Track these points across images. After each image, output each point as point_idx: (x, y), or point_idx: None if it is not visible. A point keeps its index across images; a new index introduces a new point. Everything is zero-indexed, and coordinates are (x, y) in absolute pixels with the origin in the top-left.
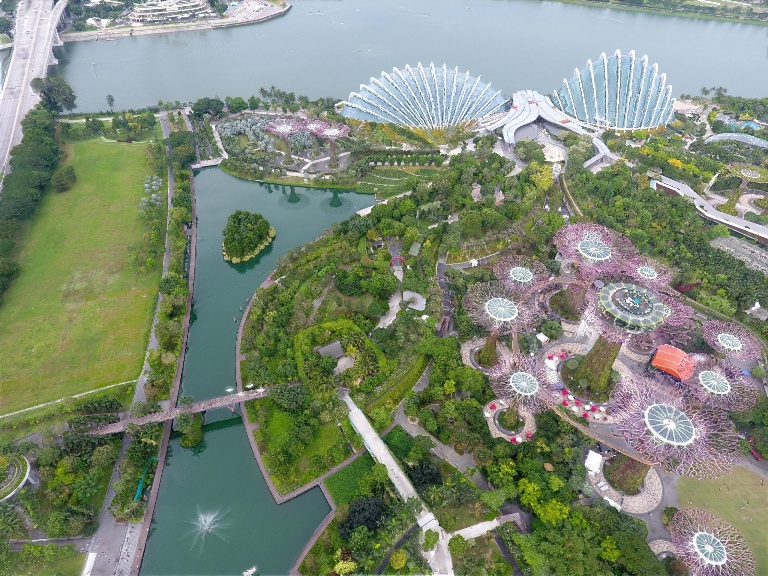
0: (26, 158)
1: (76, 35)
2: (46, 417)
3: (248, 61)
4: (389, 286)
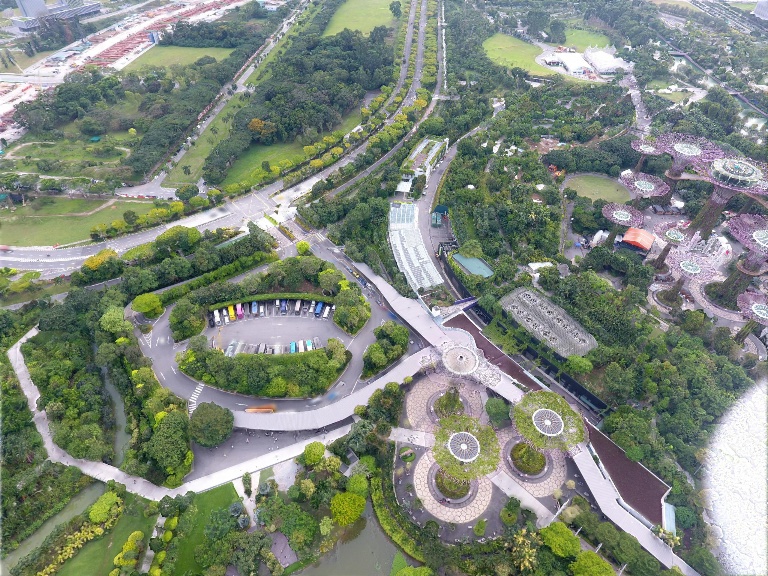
0: None
1: None
2: None
3: None
4: None
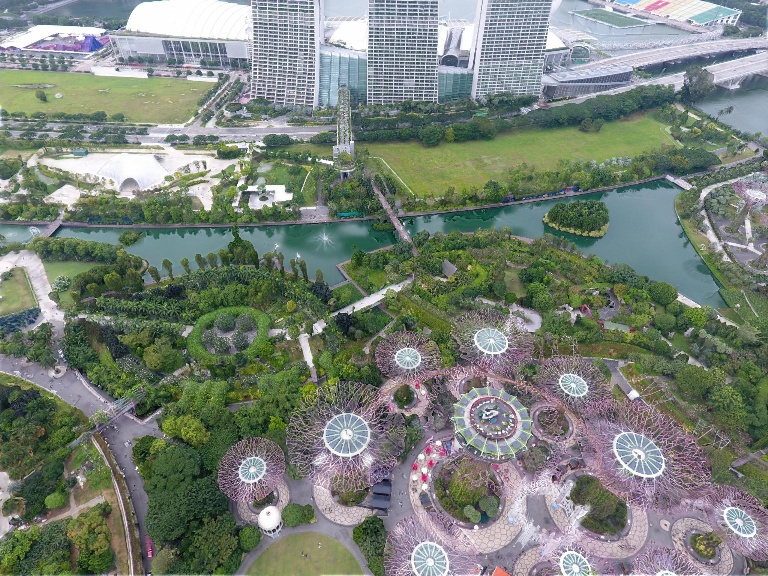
0: (597, 102)
1: None
2: None
3: None
4: (537, 299)
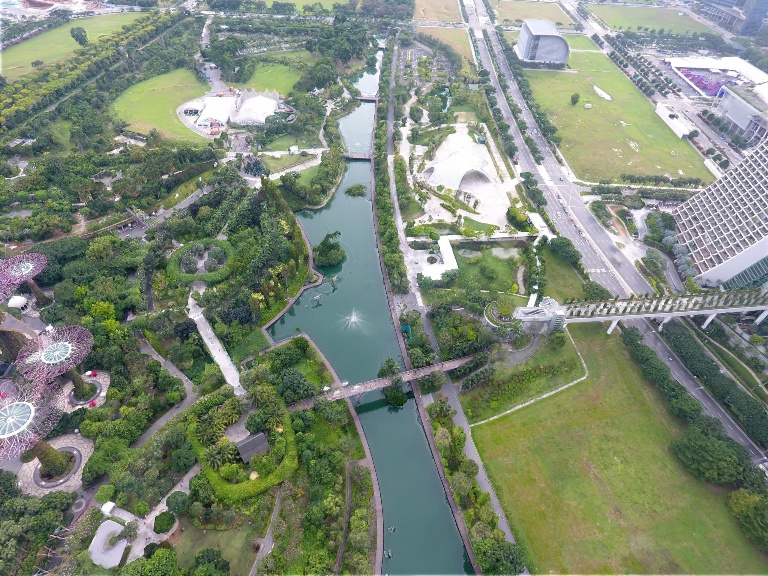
0: None
1: None
2: (521, 373)
3: None
4: None
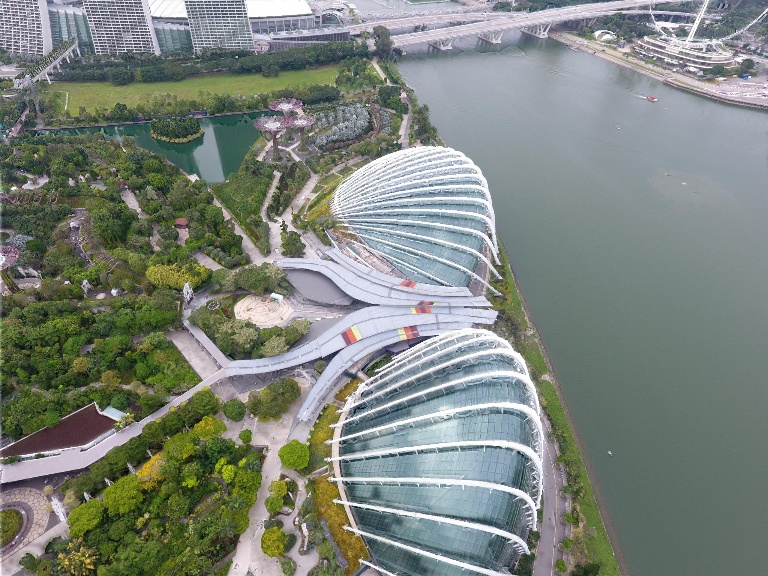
0: (285, 53)
1: (567, 36)
2: (49, 100)
3: (562, 108)
4: None
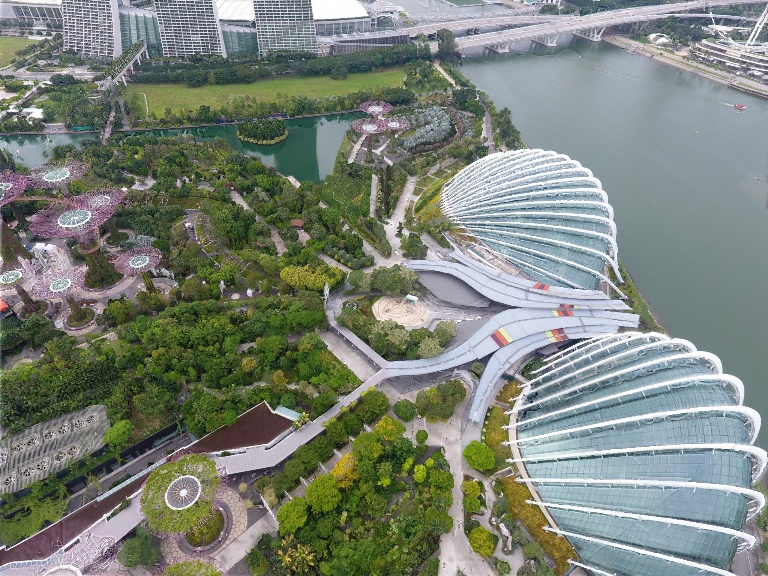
0: (351, 56)
1: (621, 39)
2: None
3: (634, 112)
4: None
